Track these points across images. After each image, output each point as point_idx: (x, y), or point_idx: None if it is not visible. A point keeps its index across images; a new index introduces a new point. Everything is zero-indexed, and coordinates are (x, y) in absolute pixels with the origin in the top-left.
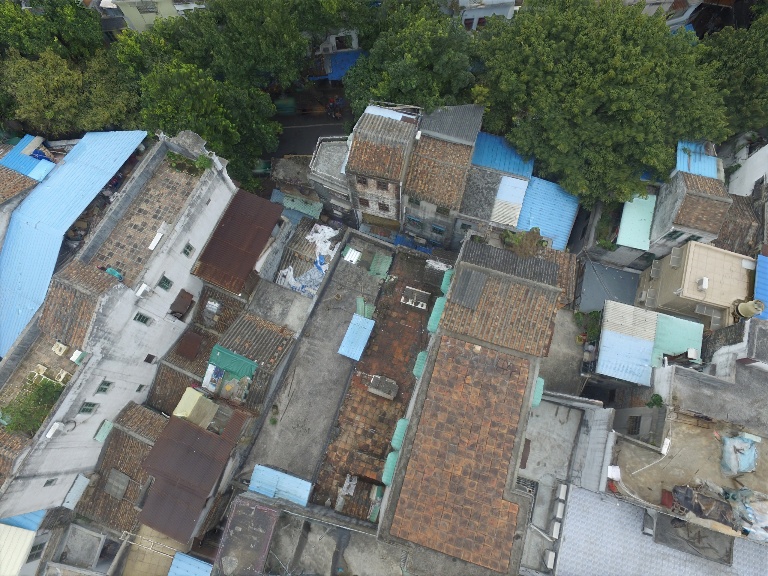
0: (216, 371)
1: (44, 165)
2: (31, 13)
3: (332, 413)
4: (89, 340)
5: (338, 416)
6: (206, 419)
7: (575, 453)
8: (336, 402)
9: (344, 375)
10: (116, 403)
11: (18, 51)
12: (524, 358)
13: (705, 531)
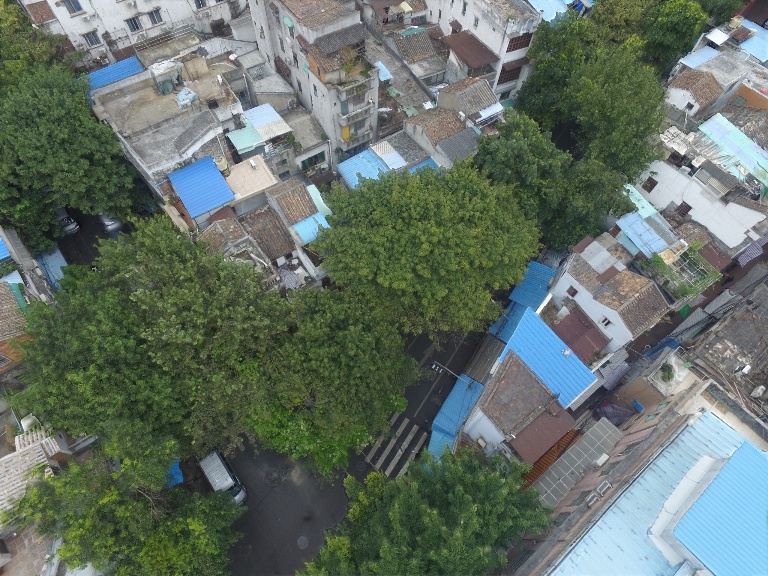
0: None
1: (569, 1)
2: (671, 6)
3: None
4: None
5: None
6: (394, 9)
7: None
8: None
9: None
10: None
11: (650, 3)
12: None
13: None
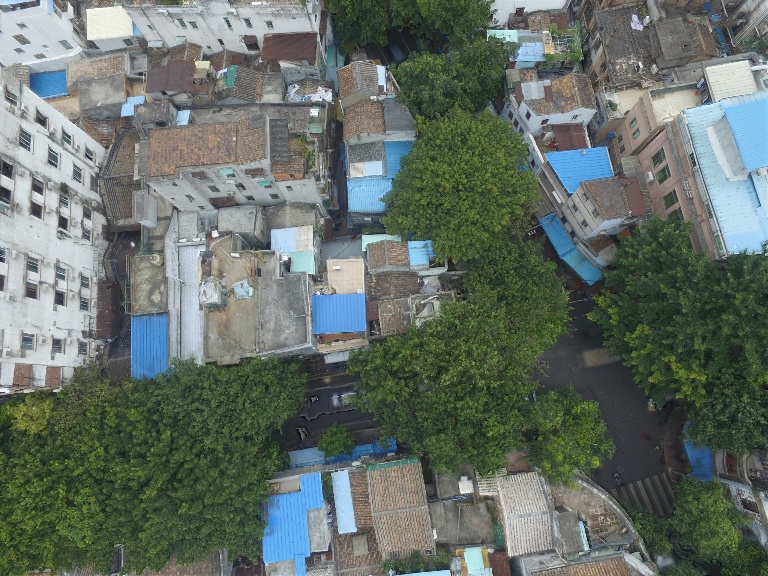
0: (225, 73)
1: None
2: None
3: None
4: (199, 1)
5: None
6: (198, 76)
7: None
8: None
9: None
10: (195, 38)
11: None
12: (237, 159)
13: None
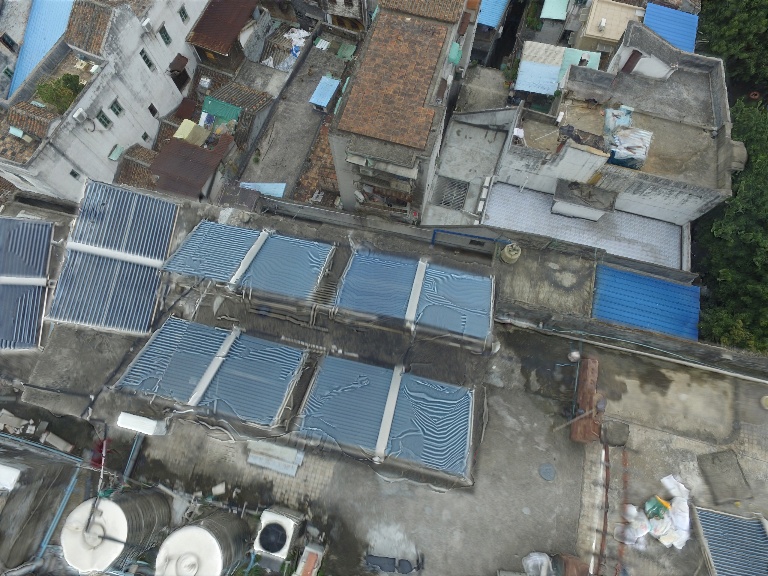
0: (208, 118)
1: None
2: None
3: (305, 154)
4: (105, 45)
5: (309, 155)
6: (200, 141)
7: (499, 160)
8: (308, 146)
9: (315, 126)
10: (126, 135)
11: None
12: None
13: (595, 191)
